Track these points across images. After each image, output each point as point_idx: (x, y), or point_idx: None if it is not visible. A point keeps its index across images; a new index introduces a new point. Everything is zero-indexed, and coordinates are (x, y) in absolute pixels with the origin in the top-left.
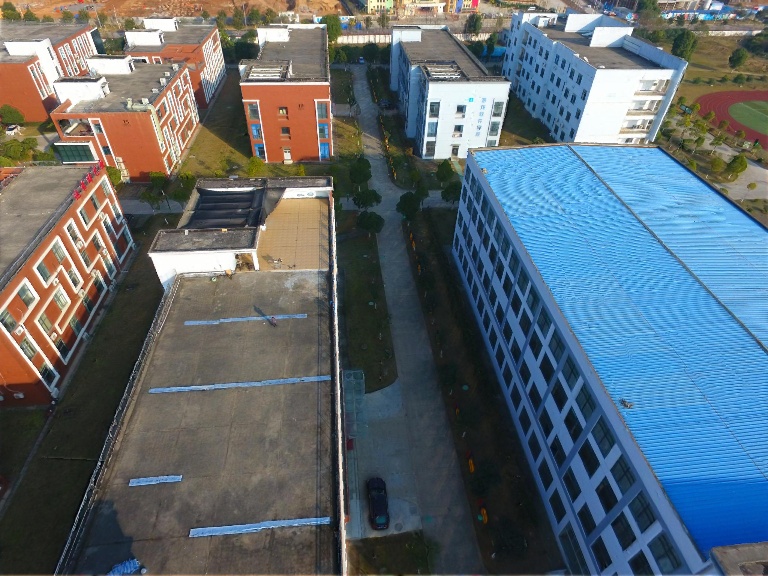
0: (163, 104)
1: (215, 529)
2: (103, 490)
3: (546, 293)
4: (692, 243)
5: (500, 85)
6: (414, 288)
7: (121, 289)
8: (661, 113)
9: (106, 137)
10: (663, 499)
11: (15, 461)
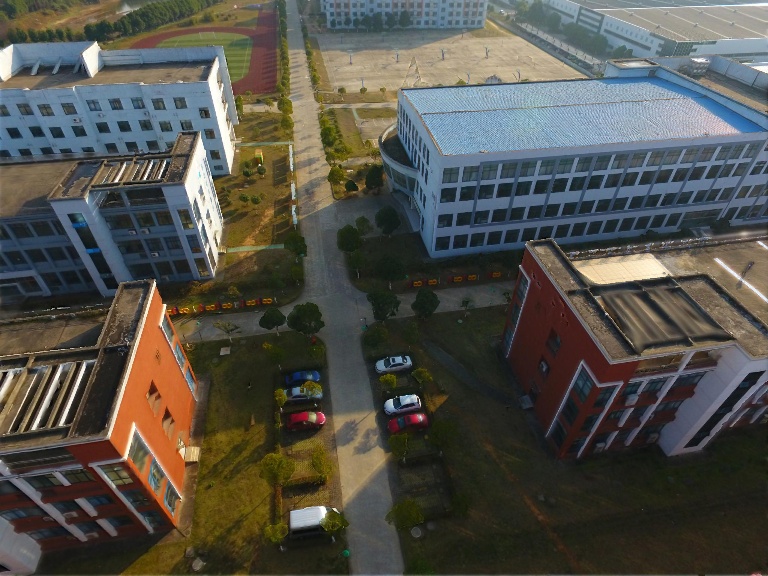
0: None
1: None
2: None
3: (637, 144)
4: (549, 100)
5: (199, 141)
6: (499, 284)
7: None
8: (228, 98)
9: None
10: (750, 134)
11: None
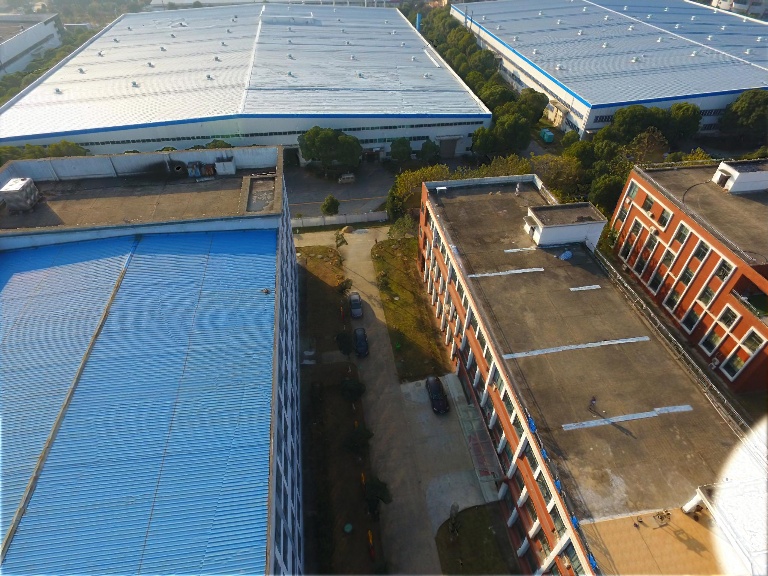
0: None
1: (531, 271)
2: (612, 283)
3: None
4: None
5: None
6: None
7: None
8: None
9: None
10: None
11: (753, 408)
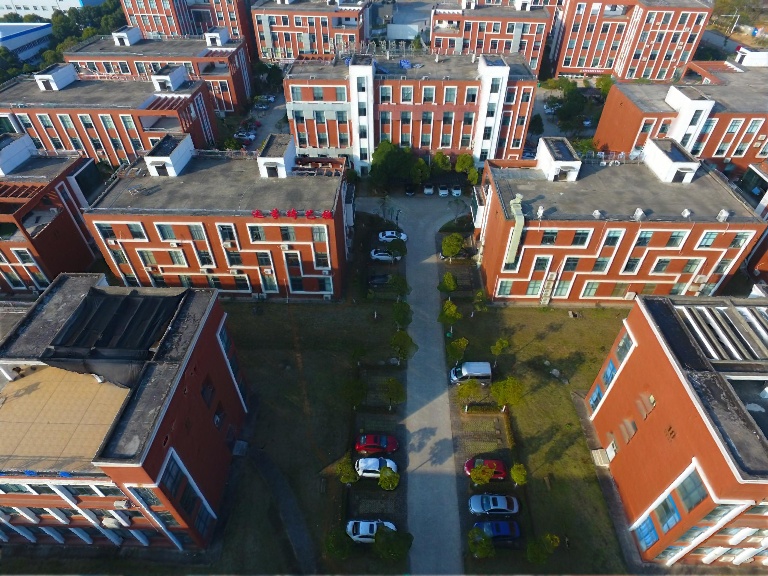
0: (581, 233)
1: None
2: None
3: None
4: None
5: None
6: None
7: (257, 304)
8: None
9: (488, 213)
10: None
11: None
